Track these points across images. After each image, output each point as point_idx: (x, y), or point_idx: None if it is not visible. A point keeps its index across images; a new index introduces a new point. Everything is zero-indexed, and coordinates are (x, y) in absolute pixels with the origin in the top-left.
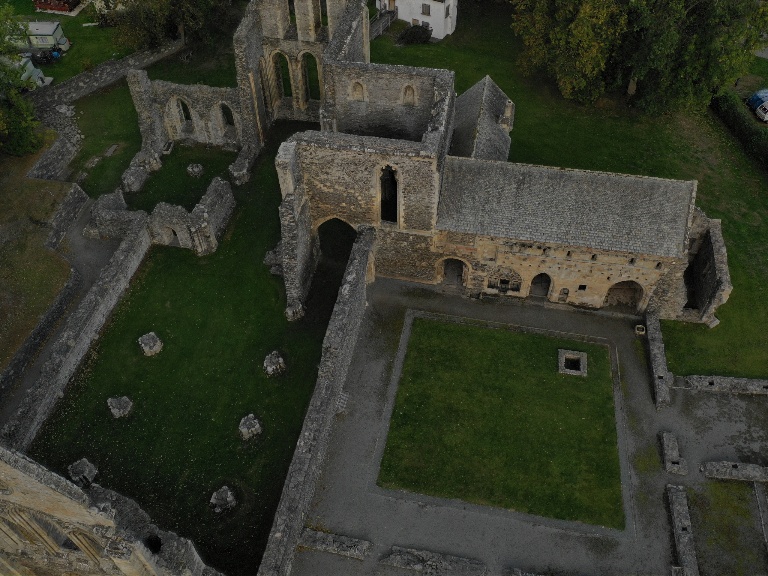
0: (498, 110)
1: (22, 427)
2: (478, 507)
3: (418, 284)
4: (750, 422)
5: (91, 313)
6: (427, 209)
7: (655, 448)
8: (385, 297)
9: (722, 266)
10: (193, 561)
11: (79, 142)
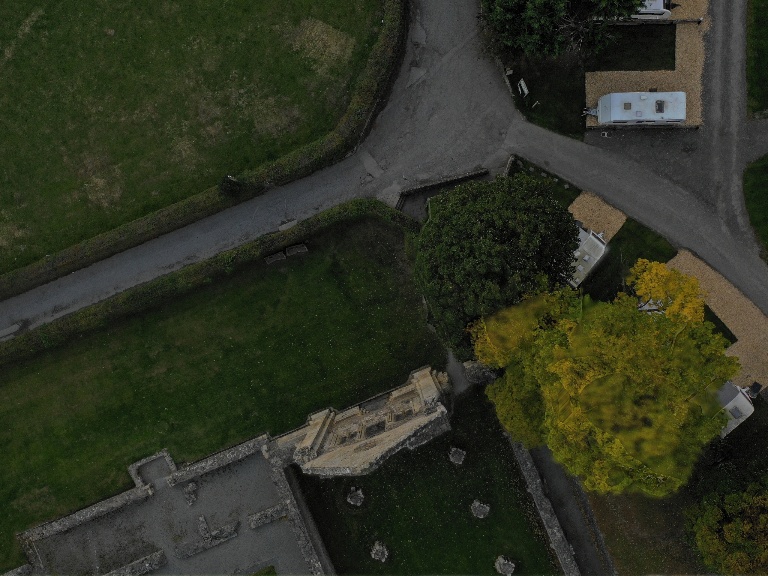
0: None
1: (521, 455)
2: None
3: None
4: None
5: None
6: None
7: None
8: None
9: None
10: None
11: None
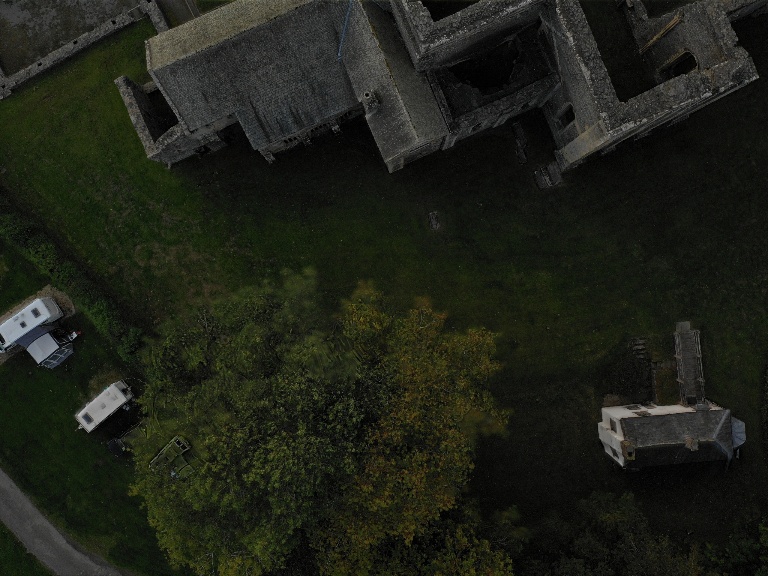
0: (386, 114)
1: None
2: None
3: None
4: (79, 8)
5: None
6: None
7: None
8: None
9: (129, 100)
10: None
11: None
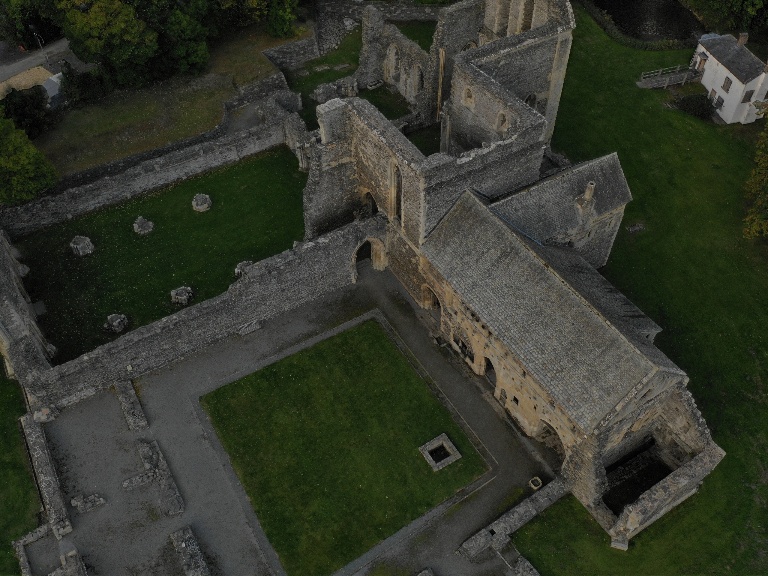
0: None
1: (85, 196)
2: (232, 473)
3: (410, 297)
4: None
5: (188, 158)
6: (417, 226)
7: (408, 574)
8: (374, 287)
9: (659, 491)
10: (11, 319)
11: (329, 50)
